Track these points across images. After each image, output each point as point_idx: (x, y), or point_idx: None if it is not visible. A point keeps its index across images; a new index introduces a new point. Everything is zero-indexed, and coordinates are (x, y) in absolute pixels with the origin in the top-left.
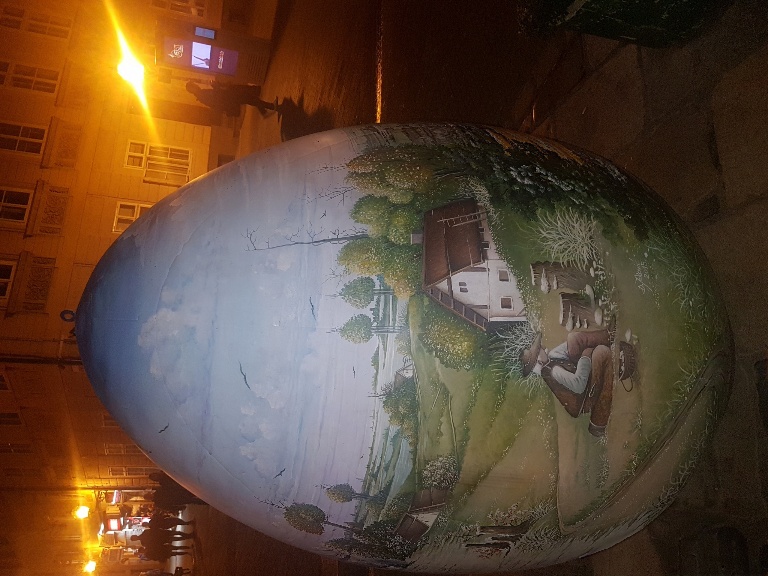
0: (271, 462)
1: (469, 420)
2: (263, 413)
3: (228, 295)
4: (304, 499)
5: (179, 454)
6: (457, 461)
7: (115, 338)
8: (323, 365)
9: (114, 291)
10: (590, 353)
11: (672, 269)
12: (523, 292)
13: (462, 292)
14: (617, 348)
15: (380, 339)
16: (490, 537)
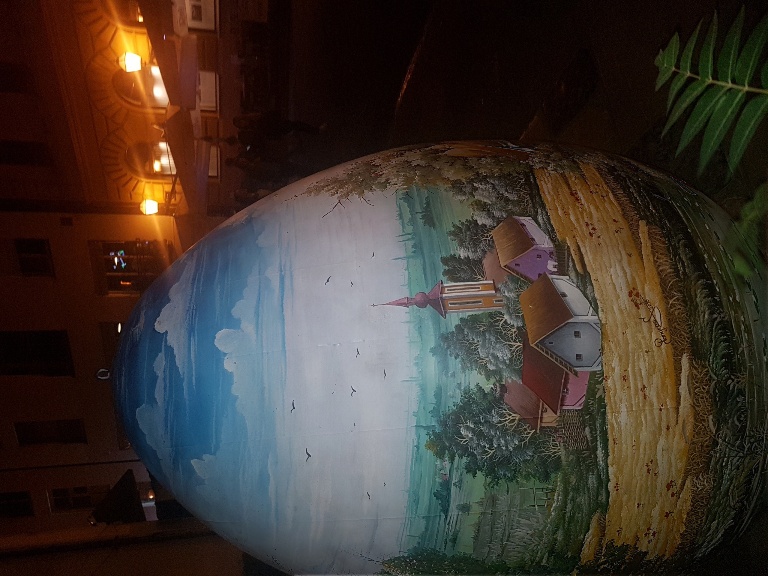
0: None
1: None
2: None
3: None
4: None
5: None
6: None
7: None
8: None
9: None
10: None
11: None
12: None
13: None
14: None
15: None
16: None
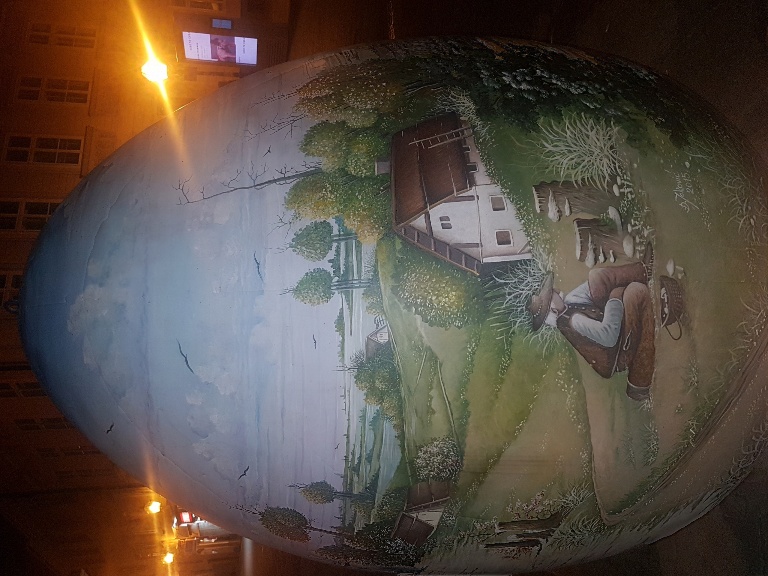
0: (231, 460)
1: (467, 391)
2: (212, 401)
3: (159, 261)
4: (278, 502)
5: (133, 457)
6: (457, 444)
7: (47, 326)
8: (276, 336)
9: (42, 271)
10: (620, 294)
11: (724, 180)
12: (525, 222)
13: (444, 229)
14: (657, 285)
15: (343, 297)
16: (513, 534)
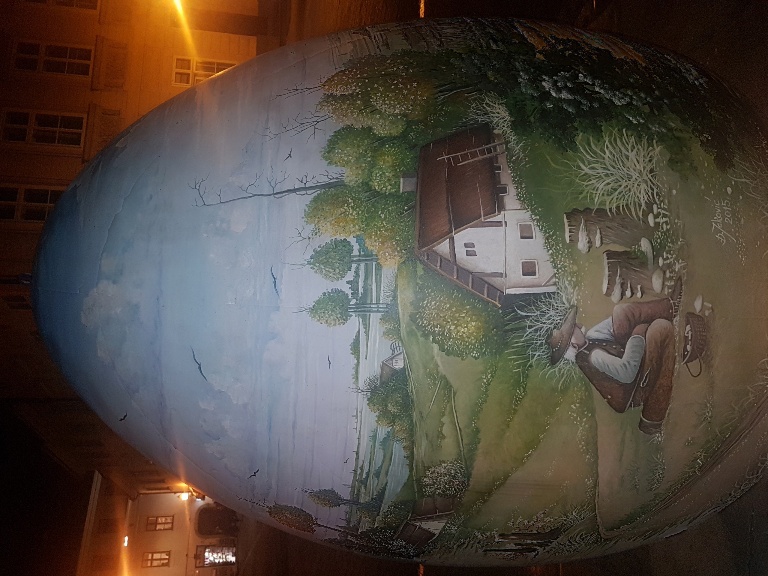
0: (242, 462)
1: (479, 420)
2: (225, 408)
3: (174, 264)
4: (286, 501)
5: (145, 444)
6: (465, 467)
7: (60, 312)
8: (290, 353)
9: (55, 256)
10: (644, 330)
11: (765, 208)
12: (553, 253)
13: (469, 256)
14: (682, 322)
15: (360, 321)
16: (512, 543)
